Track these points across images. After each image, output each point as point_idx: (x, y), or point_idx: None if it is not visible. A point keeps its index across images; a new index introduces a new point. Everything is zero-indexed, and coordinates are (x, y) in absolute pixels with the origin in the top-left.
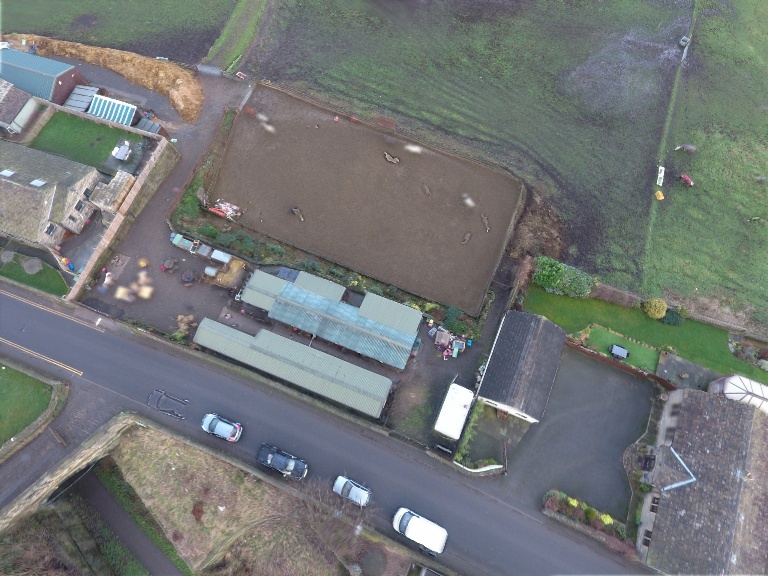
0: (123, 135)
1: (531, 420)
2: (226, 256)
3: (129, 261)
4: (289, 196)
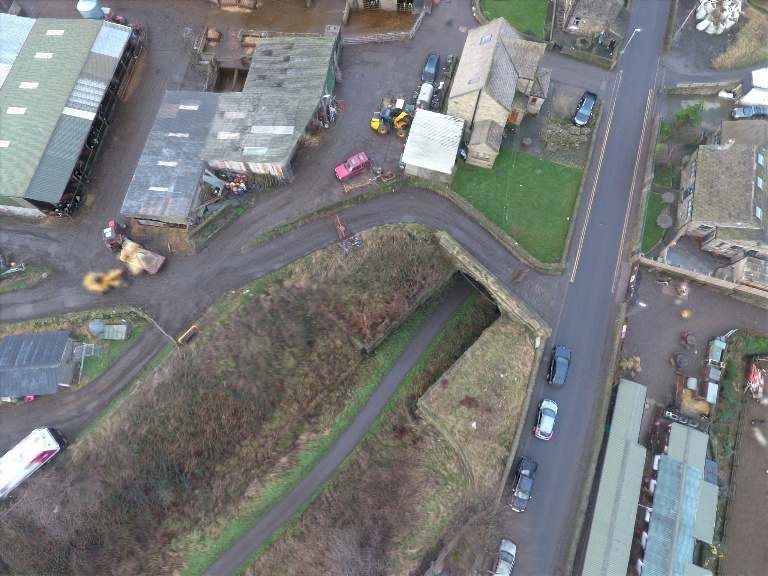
0: None
1: None
2: (714, 398)
3: (684, 300)
4: None
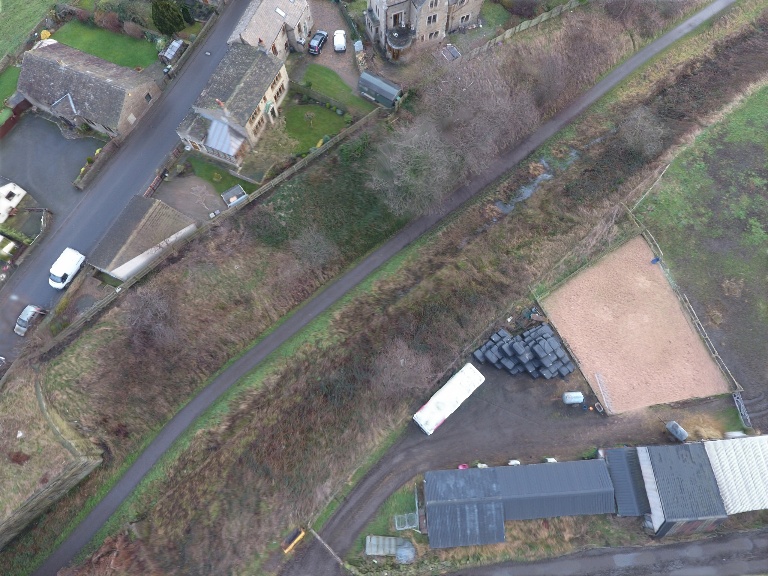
0: None
1: (20, 191)
2: None
3: None
4: None
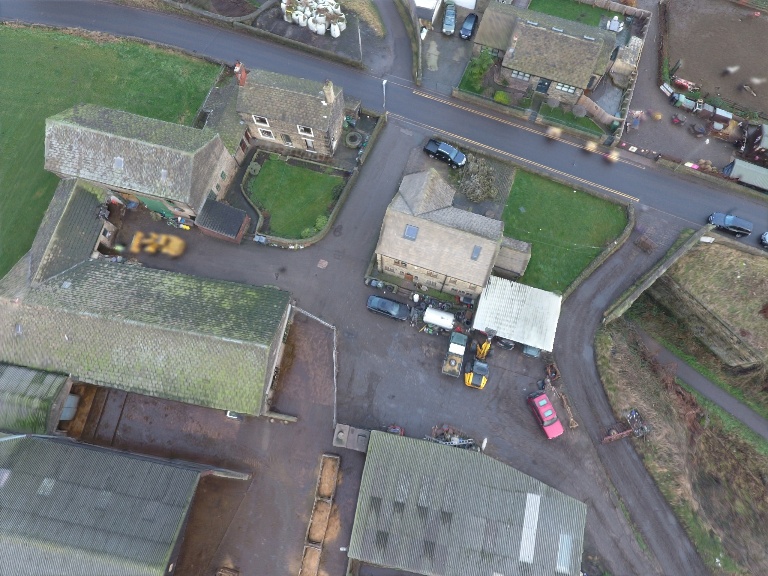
0: (603, 13)
1: None
2: (728, 113)
3: (642, 115)
4: (736, 75)
